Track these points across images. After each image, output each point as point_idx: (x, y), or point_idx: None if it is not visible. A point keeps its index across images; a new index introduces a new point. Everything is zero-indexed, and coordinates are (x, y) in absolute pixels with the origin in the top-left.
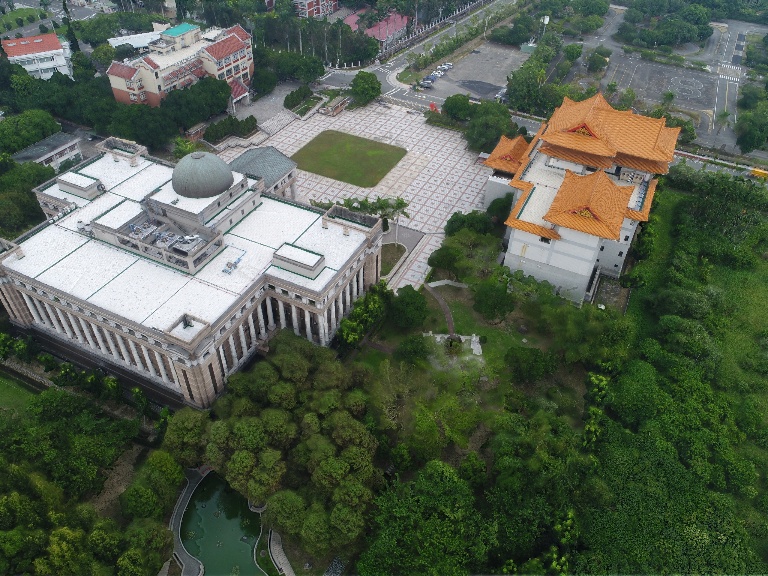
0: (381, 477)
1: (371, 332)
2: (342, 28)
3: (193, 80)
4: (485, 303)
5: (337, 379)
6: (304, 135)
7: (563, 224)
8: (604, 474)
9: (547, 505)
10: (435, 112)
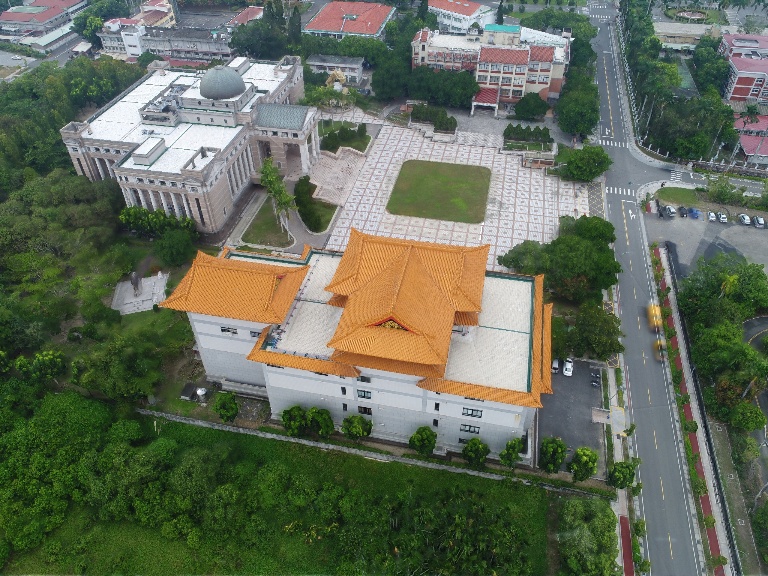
0: (3, 259)
1: None
2: (721, 116)
3: None
4: None
5: (74, 215)
6: (468, 158)
7: None
8: None
9: None
10: (571, 222)
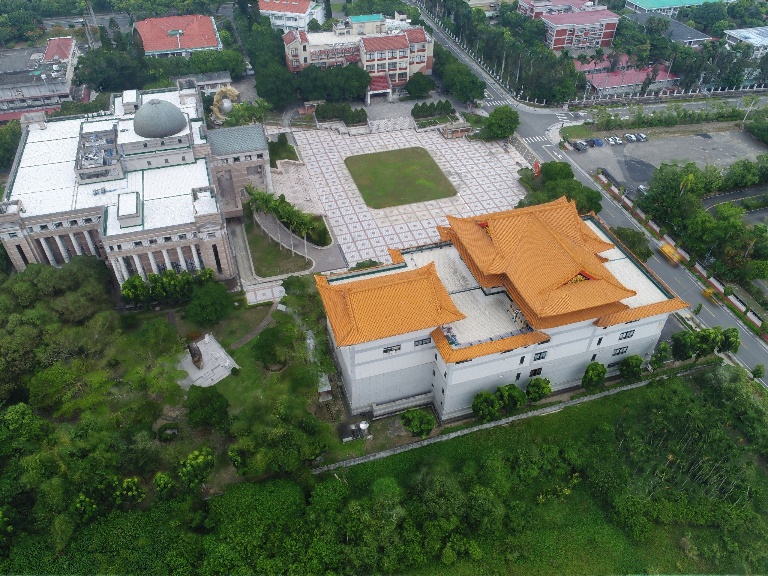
0: (3, 390)
1: (184, 308)
2: None
3: (344, 63)
4: None
5: (67, 308)
6: (396, 143)
7: (326, 301)
8: (94, 527)
9: (6, 494)
10: (530, 172)
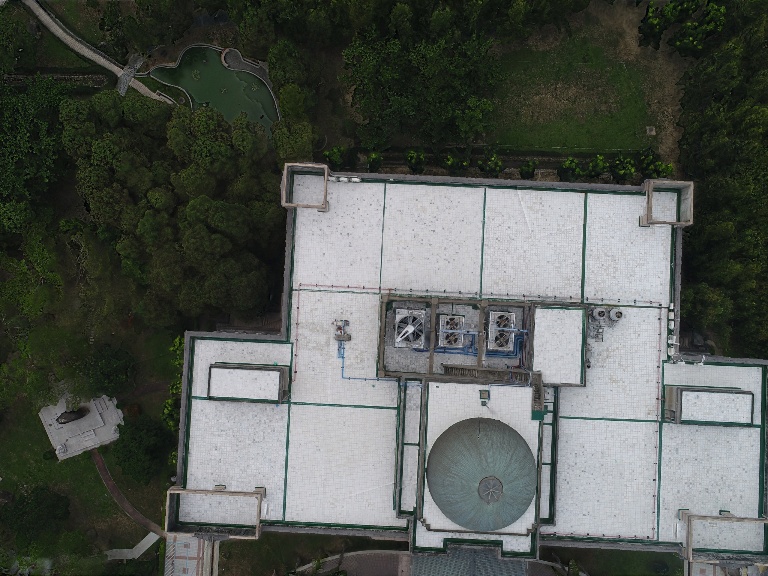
0: None
1: None
2: None
3: None
4: (43, 504)
5: None
6: None
7: None
8: None
9: None
10: None
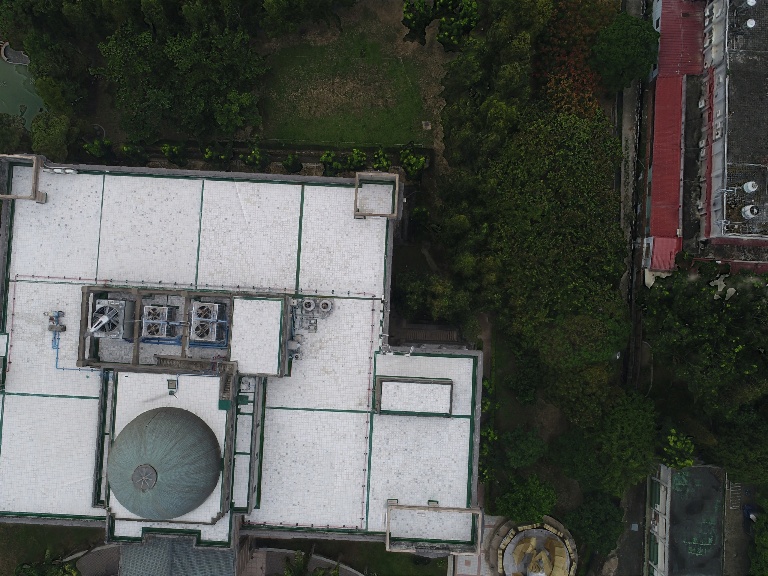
0: None
1: None
2: None
3: None
4: None
5: None
6: None
7: None
8: None
9: None
10: None
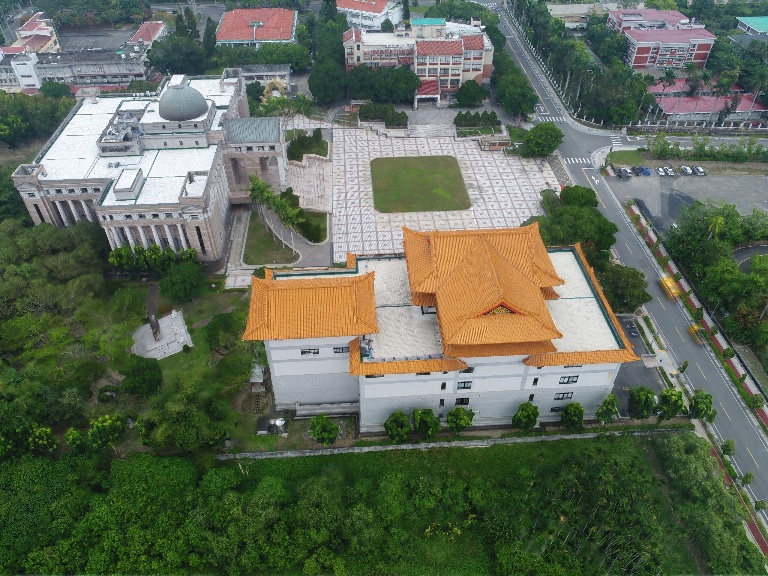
0: None
1: None
2: (636, 83)
3: None
4: None
5: (57, 266)
6: (429, 150)
7: (254, 295)
8: (5, 465)
9: None
10: (553, 194)
